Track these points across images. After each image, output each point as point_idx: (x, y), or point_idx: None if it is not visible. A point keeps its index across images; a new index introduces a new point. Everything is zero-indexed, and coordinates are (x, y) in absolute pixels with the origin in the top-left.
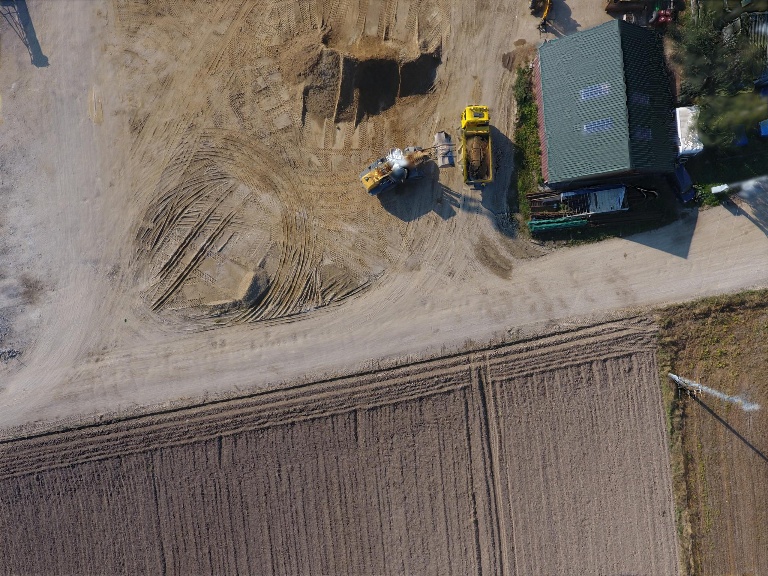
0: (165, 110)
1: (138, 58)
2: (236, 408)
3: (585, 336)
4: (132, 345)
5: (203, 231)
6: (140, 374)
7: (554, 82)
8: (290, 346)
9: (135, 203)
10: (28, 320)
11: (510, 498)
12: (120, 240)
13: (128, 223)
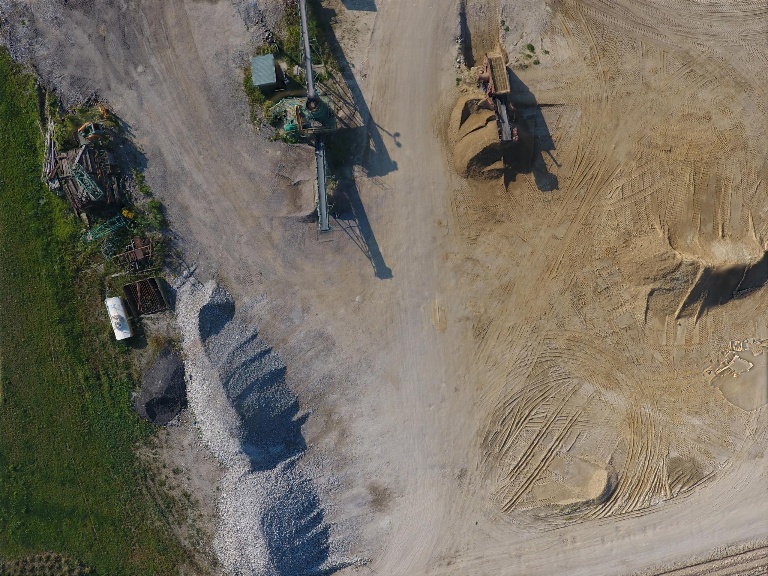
0: (508, 314)
1: (479, 265)
2: None
3: None
4: (484, 547)
5: (550, 431)
6: (493, 575)
7: None
8: (641, 539)
9: (481, 407)
10: (378, 528)
11: None
12: (467, 444)
13: (475, 427)
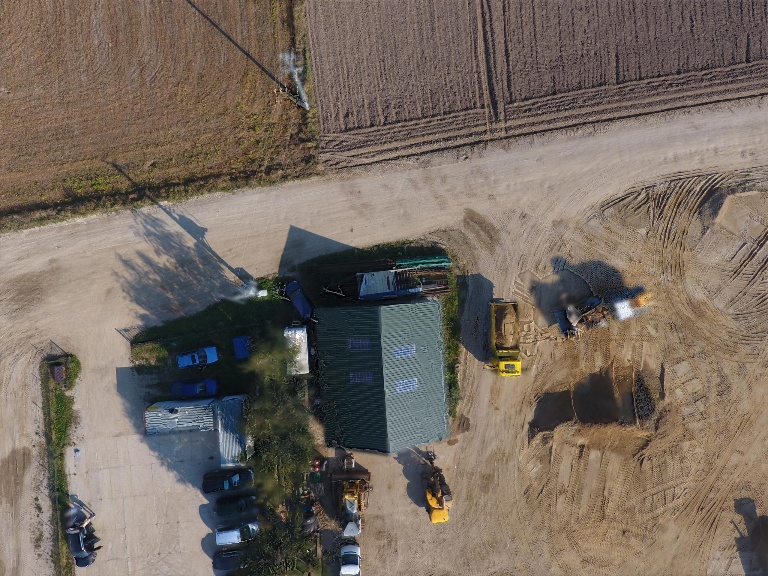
0: None
1: None
2: (732, 90)
3: (392, 151)
4: None
5: (759, 264)
6: None
7: (435, 398)
8: (680, 149)
9: None
10: None
11: None
12: None
13: None
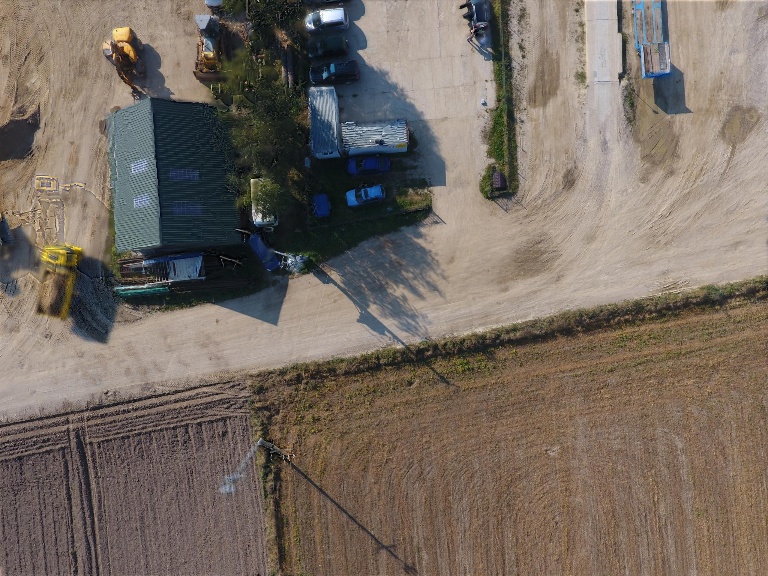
0: None
1: None
2: None
3: (180, 400)
4: None
5: None
6: None
7: None
8: None
9: None
10: None
11: (110, 557)
12: None
13: None
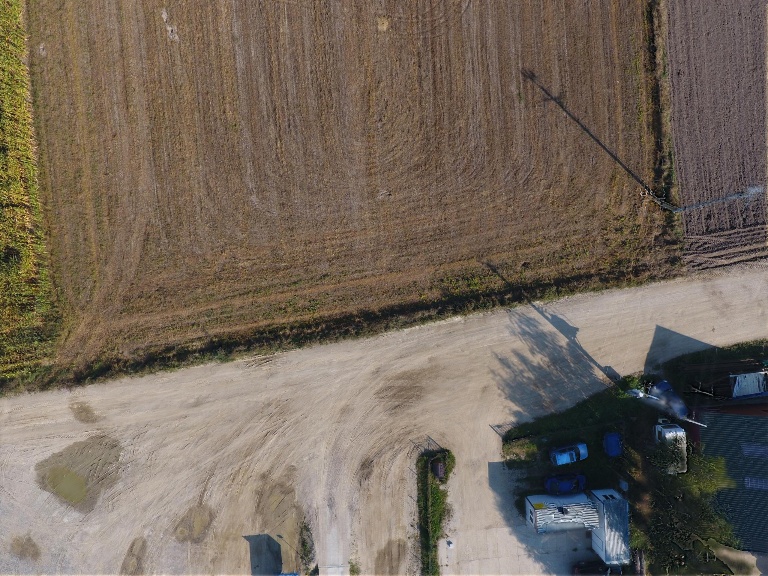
0: None
1: None
2: None
3: (751, 252)
4: None
5: None
6: None
7: None
8: None
9: None
10: None
11: None
12: None
13: None
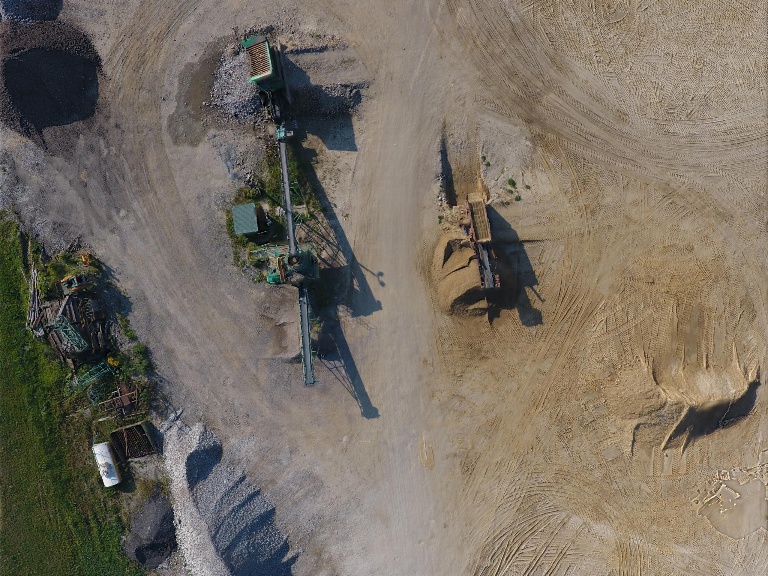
0: (495, 450)
1: (465, 401)
2: None
3: None
4: None
5: (540, 565)
6: None
7: None
8: None
9: (470, 542)
10: None
11: None
12: None
13: (465, 562)
